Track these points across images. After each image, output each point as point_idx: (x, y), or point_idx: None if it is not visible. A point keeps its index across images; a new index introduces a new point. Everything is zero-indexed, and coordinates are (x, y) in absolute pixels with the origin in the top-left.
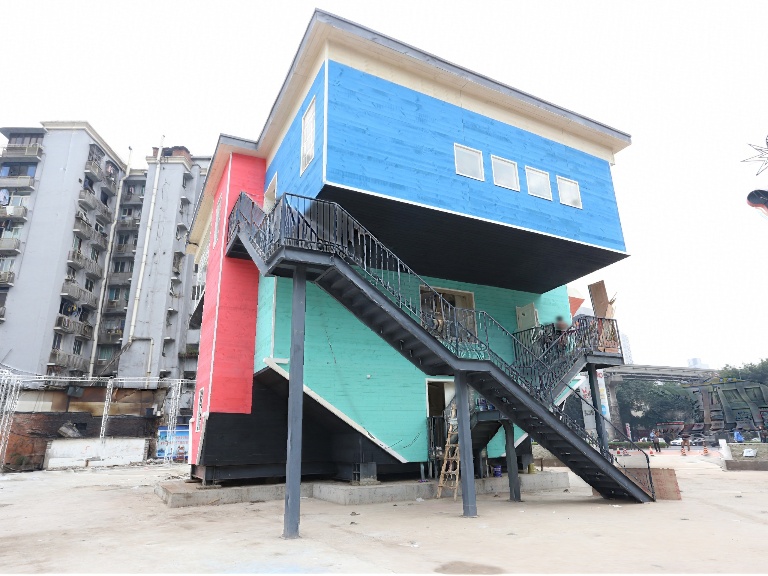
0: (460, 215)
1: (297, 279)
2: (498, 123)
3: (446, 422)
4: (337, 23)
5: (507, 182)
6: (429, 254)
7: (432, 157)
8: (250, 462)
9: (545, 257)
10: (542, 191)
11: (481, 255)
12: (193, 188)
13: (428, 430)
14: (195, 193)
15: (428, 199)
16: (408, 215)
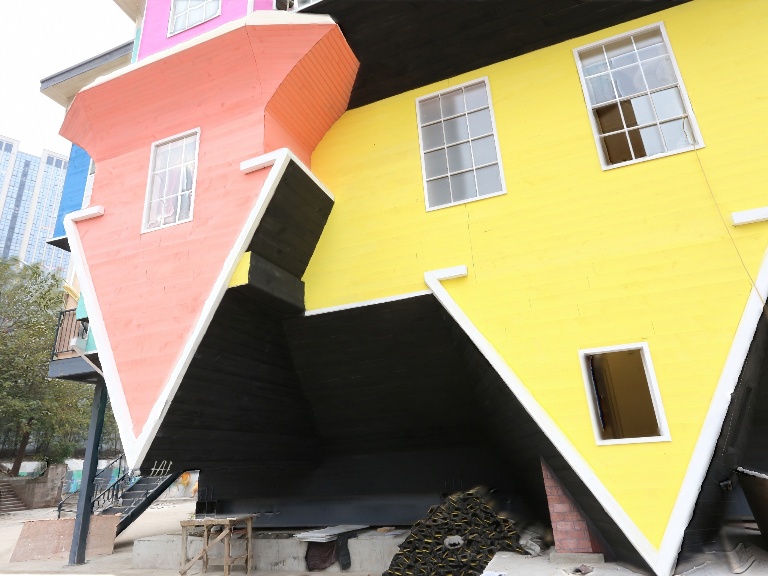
0: None
1: None
2: None
3: None
4: None
5: None
6: None
7: None
8: None
9: None
10: None
11: None
12: None
13: None
14: None
15: None
16: None
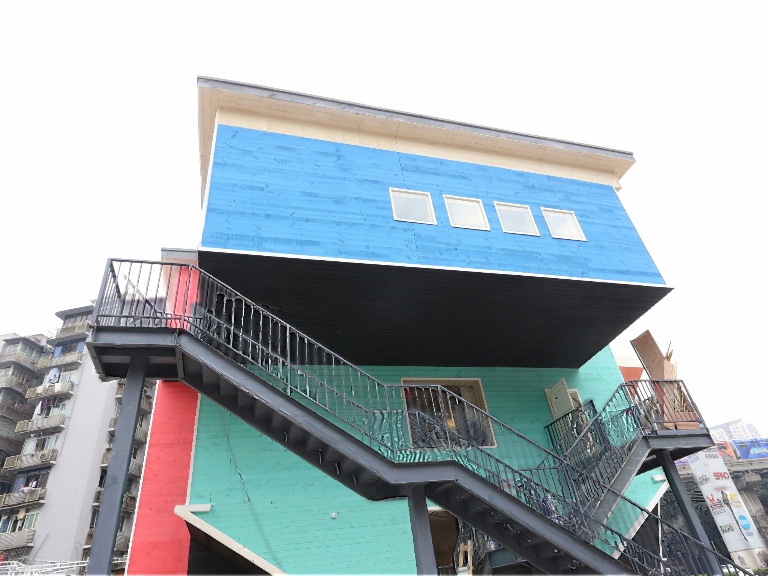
0: (402, 266)
1: (128, 374)
2: (450, 162)
3: (457, 574)
4: (224, 86)
5: (471, 222)
6: (395, 333)
7: (359, 206)
8: None
9: (554, 311)
10: (524, 227)
11: (465, 323)
12: None
13: None
14: None
15: (354, 253)
16: (333, 278)
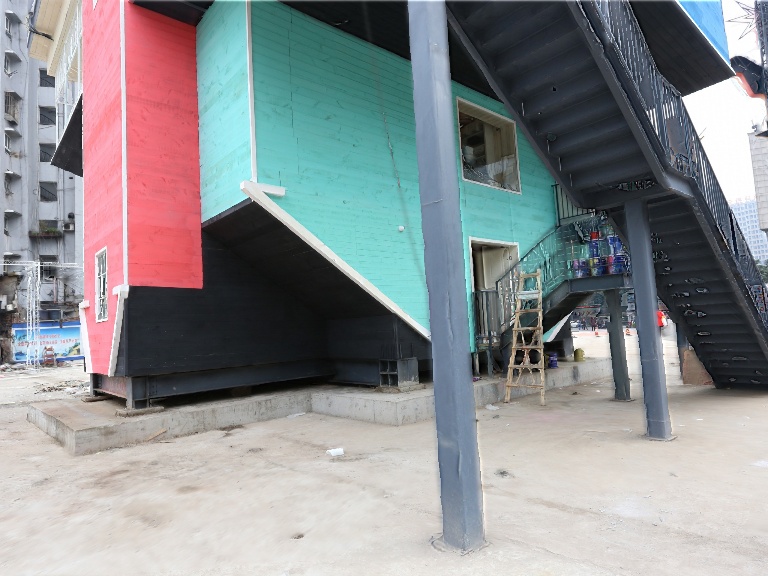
0: None
1: None
2: None
3: (502, 297)
4: None
5: None
6: None
7: None
8: (208, 366)
9: None
10: None
11: None
12: (23, 1)
13: (475, 309)
14: (27, 9)
15: None
16: None
